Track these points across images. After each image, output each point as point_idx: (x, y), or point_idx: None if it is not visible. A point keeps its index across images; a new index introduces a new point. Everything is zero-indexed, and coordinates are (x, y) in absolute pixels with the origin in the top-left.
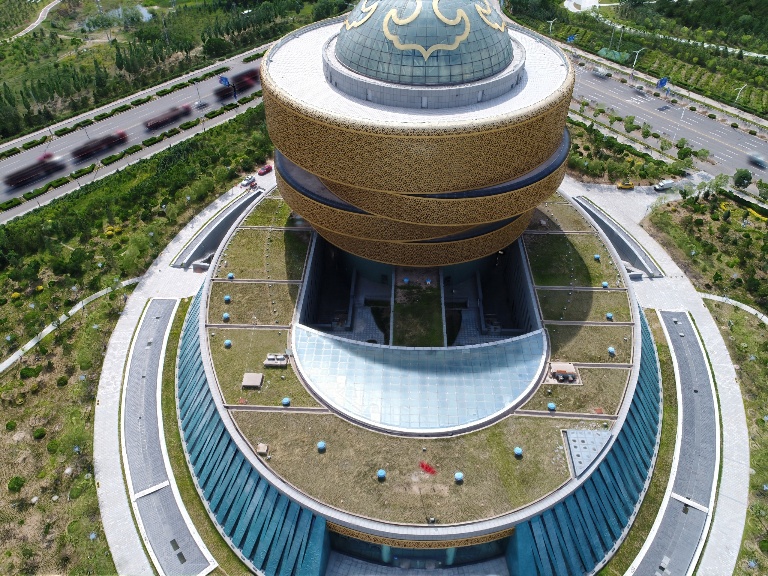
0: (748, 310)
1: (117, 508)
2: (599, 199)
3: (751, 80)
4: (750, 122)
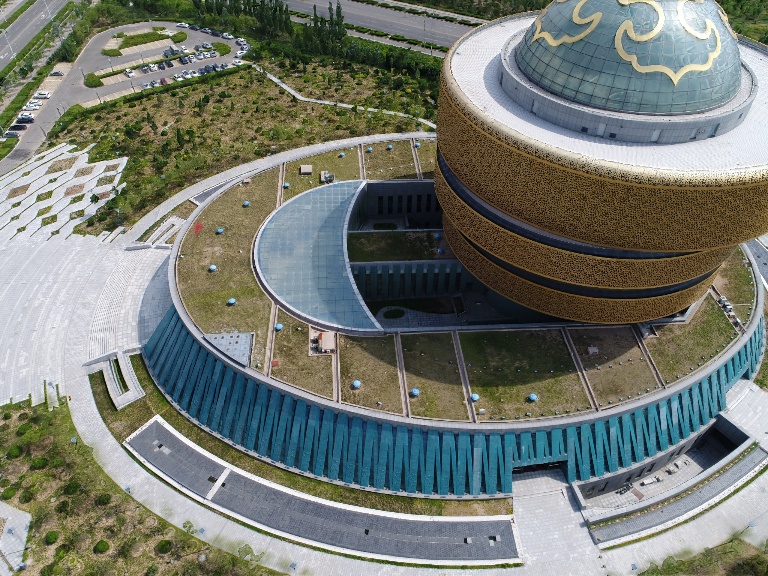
0: None
1: (247, 168)
2: None
3: None
4: None
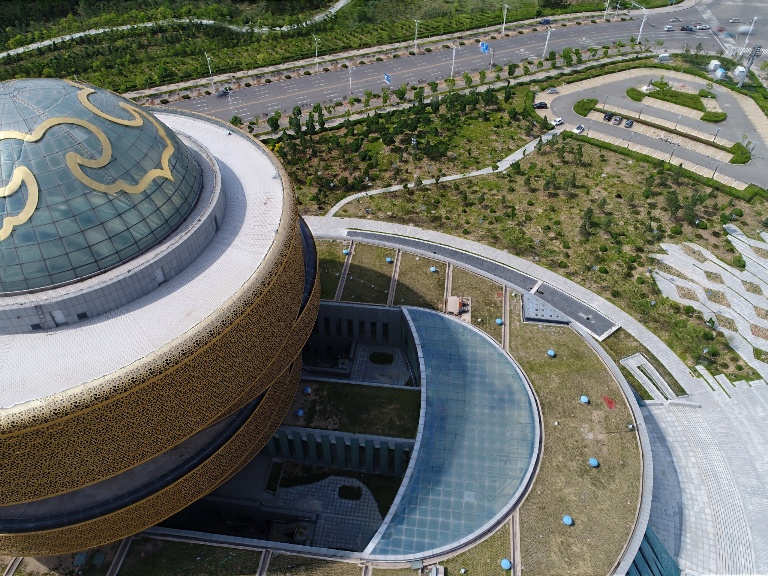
0: (353, 198)
1: None
2: None
3: (44, 76)
4: None
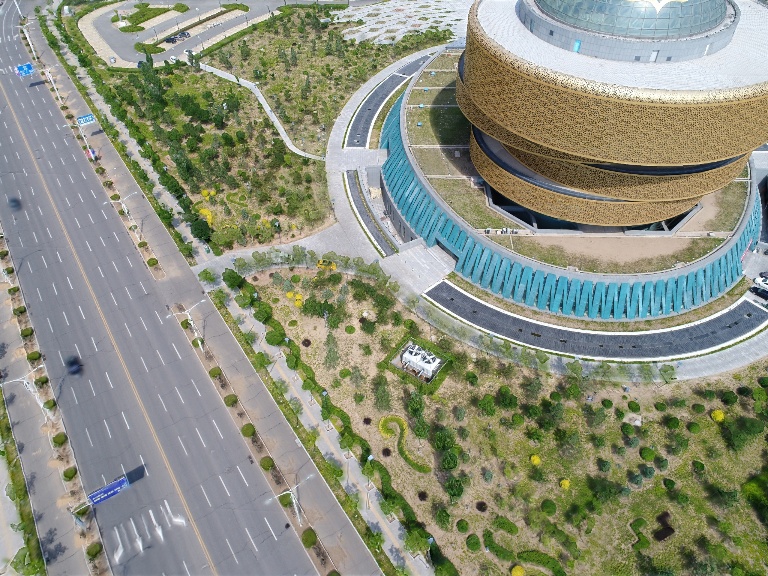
0: (296, 149)
1: None
2: (366, 253)
3: None
4: (6, 420)
